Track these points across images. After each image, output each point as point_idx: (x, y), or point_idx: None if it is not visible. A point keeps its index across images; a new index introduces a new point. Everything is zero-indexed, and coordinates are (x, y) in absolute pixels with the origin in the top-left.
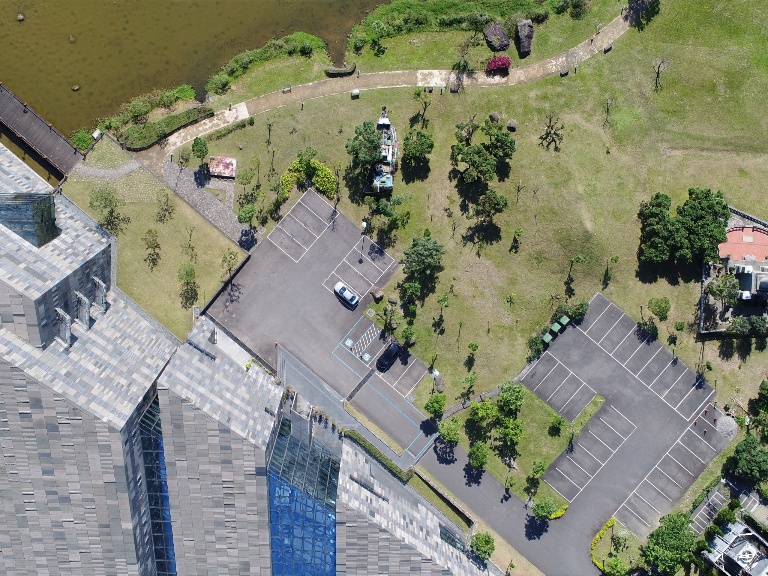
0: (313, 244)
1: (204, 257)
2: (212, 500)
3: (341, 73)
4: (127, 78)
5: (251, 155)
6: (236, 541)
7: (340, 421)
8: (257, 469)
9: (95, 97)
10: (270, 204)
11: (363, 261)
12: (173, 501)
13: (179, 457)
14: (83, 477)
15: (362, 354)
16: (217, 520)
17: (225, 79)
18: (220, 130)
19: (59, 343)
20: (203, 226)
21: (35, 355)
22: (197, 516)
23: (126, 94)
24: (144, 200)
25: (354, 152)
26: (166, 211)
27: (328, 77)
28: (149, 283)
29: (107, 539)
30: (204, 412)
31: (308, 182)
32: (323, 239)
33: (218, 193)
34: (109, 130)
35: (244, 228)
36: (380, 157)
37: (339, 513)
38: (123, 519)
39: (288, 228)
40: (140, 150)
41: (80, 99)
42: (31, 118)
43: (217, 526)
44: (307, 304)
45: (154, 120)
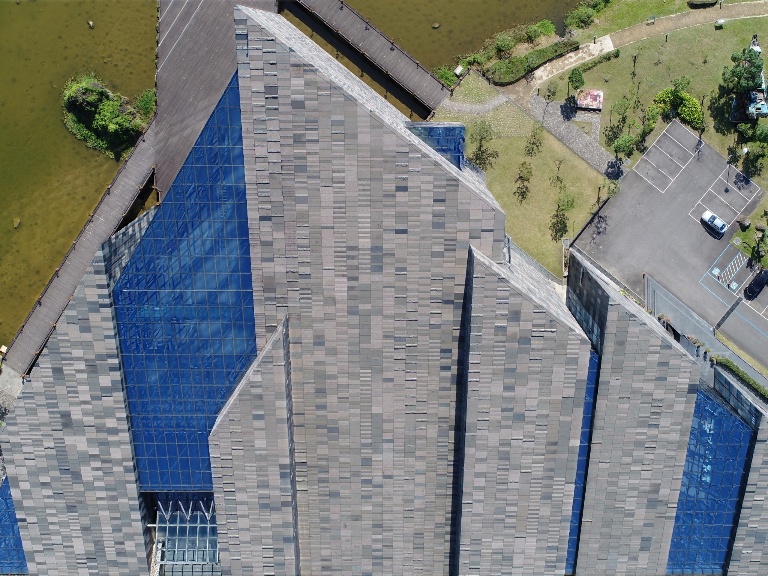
0: (679, 174)
1: (573, 189)
2: (637, 420)
3: (705, 4)
4: (486, 15)
5: (616, 87)
6: (652, 462)
7: (711, 349)
8: (690, 386)
9: (455, 34)
10: (637, 135)
11: (729, 190)
12: (598, 422)
13: (614, 375)
14: (542, 392)
15: (729, 282)
16: (638, 441)
17: (592, 12)
18: (586, 63)
19: (503, 262)
20: (571, 158)
21: (502, 270)
22: (619, 437)
23: (486, 31)
24: (512, 134)
25: (730, 79)
26: (534, 144)
27: (691, 8)
28: (519, 216)
29: (551, 457)
30: (650, 327)
31: (672, 113)
32: (688, 169)
33: (584, 126)
34: (471, 66)
35: (610, 160)
36: (761, 83)
37: (762, 430)
38: (572, 436)
39: (653, 159)
40: (507, 85)
41: (440, 37)
42: (398, 55)
43: (636, 447)
44: (674, 234)
45: (519, 55)
